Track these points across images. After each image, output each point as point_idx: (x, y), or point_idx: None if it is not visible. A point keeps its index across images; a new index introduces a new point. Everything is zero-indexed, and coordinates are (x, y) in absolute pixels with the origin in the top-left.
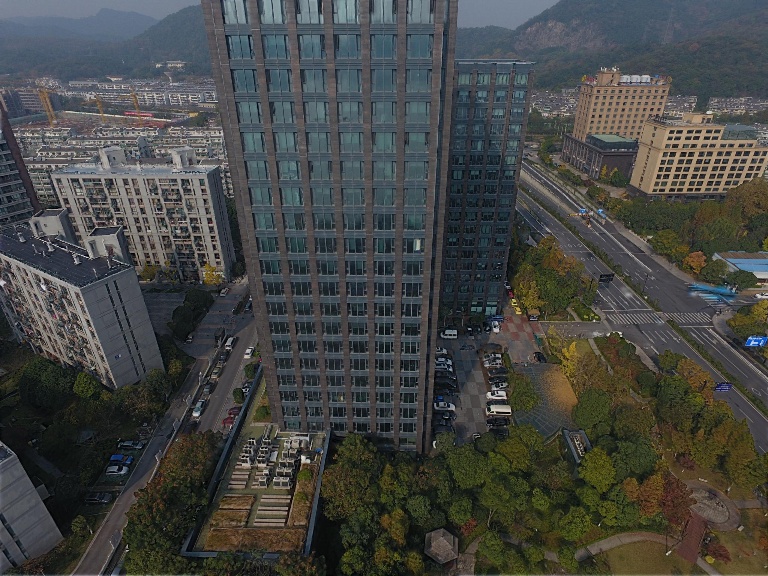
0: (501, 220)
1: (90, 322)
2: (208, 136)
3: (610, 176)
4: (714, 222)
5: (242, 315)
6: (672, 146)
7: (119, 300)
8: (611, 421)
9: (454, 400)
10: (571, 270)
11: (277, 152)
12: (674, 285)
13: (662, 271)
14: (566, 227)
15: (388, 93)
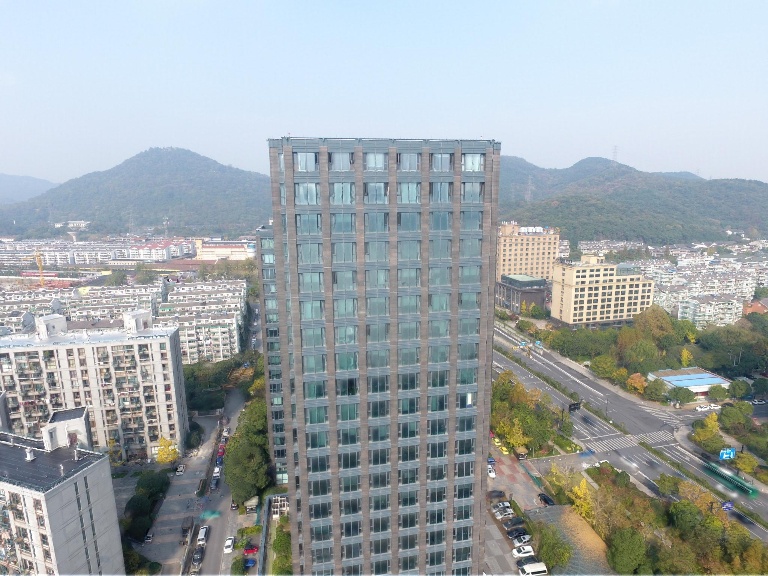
0: None
1: (48, 538)
2: (135, 294)
3: (530, 310)
4: (637, 345)
5: (208, 496)
6: (581, 283)
7: (87, 501)
8: (650, 562)
9: None
10: (539, 402)
11: (335, 318)
12: (627, 407)
13: (611, 394)
14: (512, 360)
15: (444, 260)
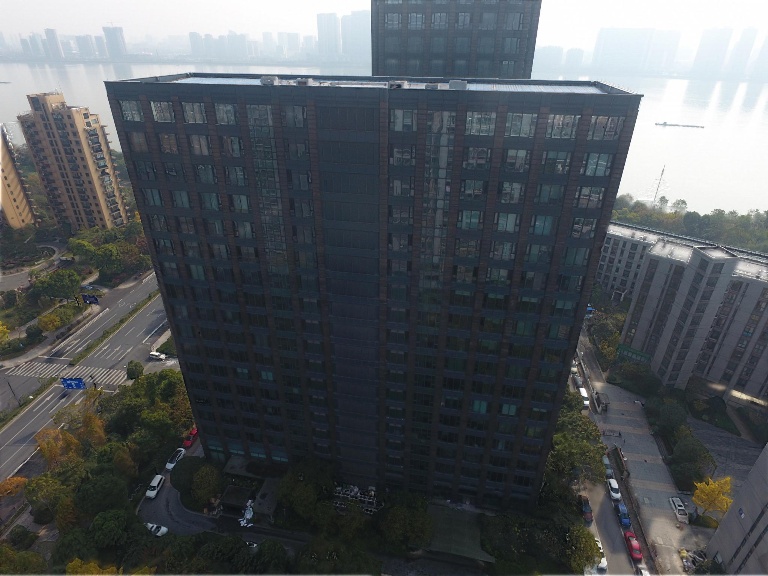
0: None
1: None
2: None
3: None
4: None
5: None
6: None
7: None
8: None
9: None
10: (75, 424)
11: None
12: None
13: None
14: None
15: None
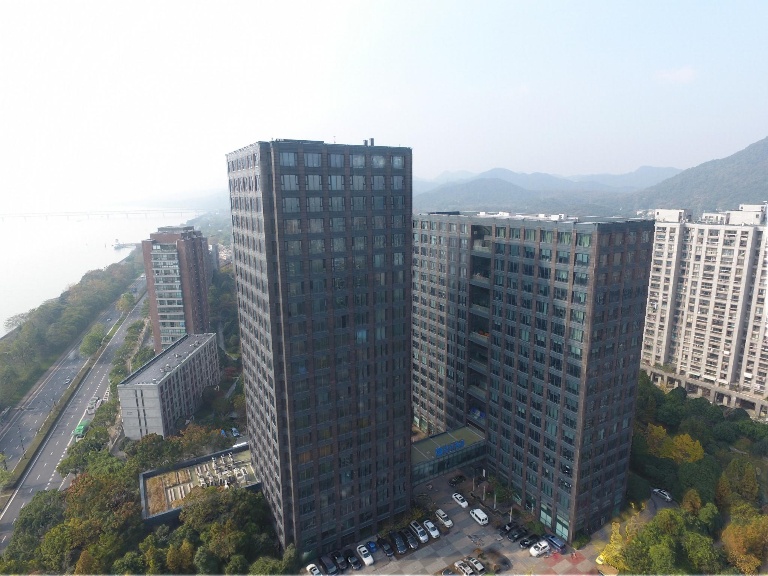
0: (569, 408)
1: None
2: None
3: None
4: None
5: None
6: None
7: None
8: None
9: (383, 560)
10: None
11: None
12: None
13: None
14: None
15: None
